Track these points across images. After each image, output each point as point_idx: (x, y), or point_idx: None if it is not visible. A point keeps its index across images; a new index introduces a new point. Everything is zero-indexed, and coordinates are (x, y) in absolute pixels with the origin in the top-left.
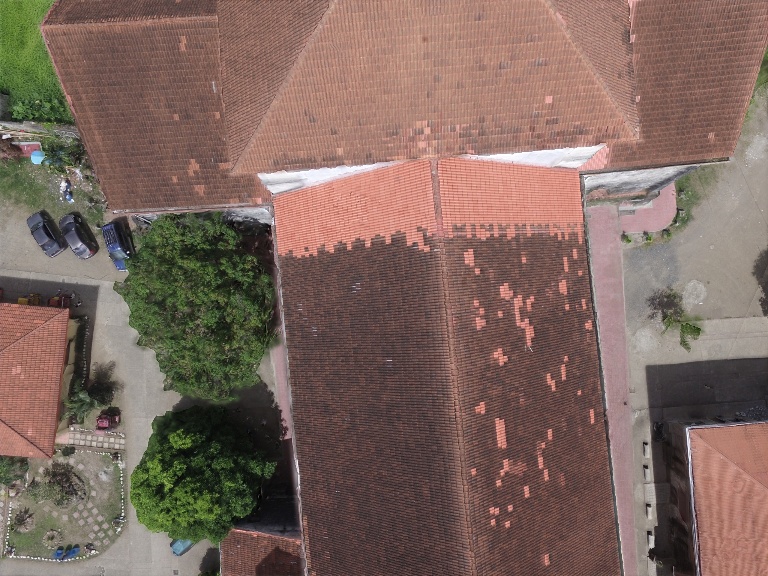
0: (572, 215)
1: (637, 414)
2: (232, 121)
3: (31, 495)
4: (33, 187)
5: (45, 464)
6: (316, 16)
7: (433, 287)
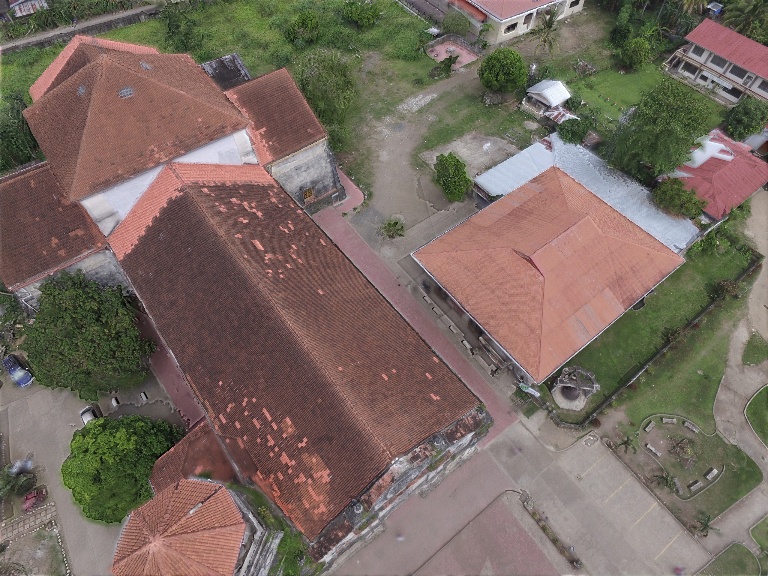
0: (266, 179)
1: (409, 286)
2: (63, 184)
3: None
4: None
5: None
6: (84, 123)
7: (190, 204)
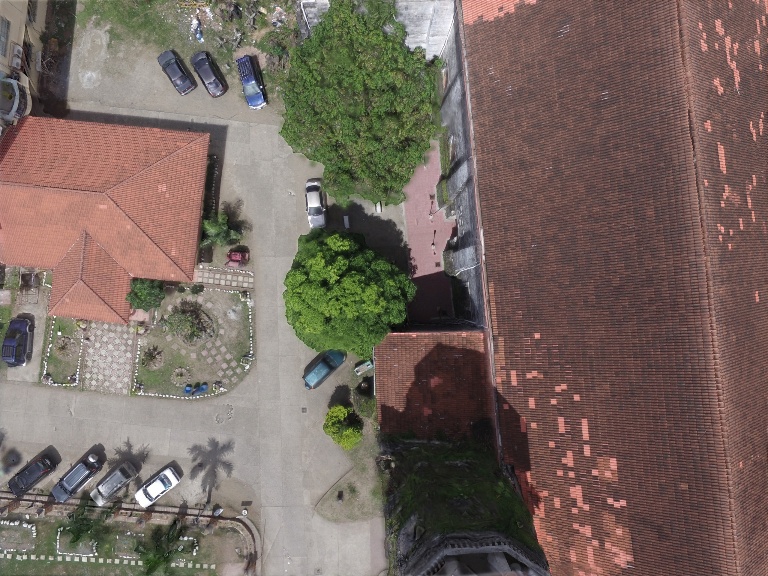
0: None
1: None
2: None
3: (166, 325)
4: (163, 27)
5: (174, 302)
6: None
7: (663, 3)
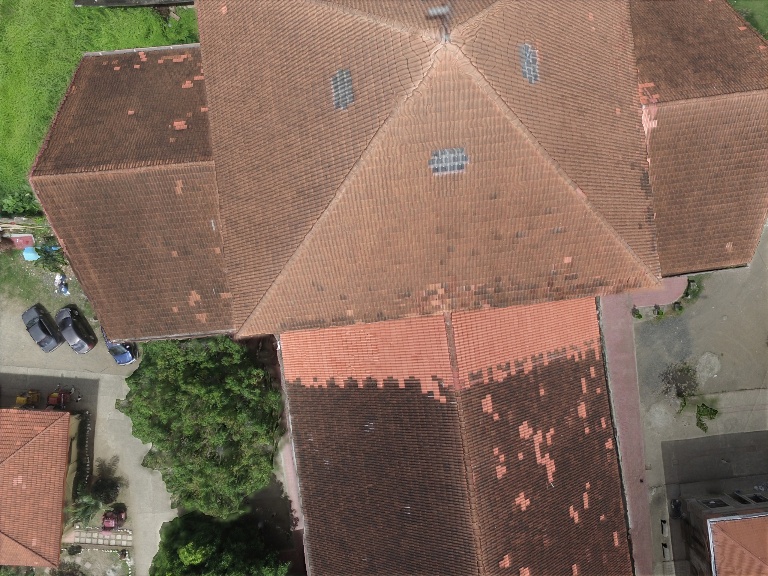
0: (588, 331)
1: (654, 491)
2: (235, 283)
3: None
4: (27, 280)
5: None
6: (322, 201)
7: (451, 440)
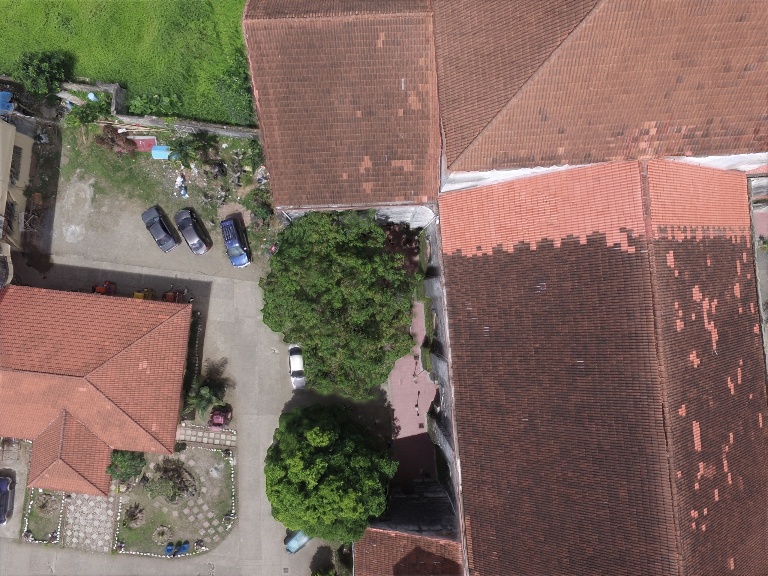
0: (742, 218)
1: None
2: (451, 119)
3: (147, 491)
4: (147, 182)
5: (156, 460)
6: (578, 14)
7: (638, 288)
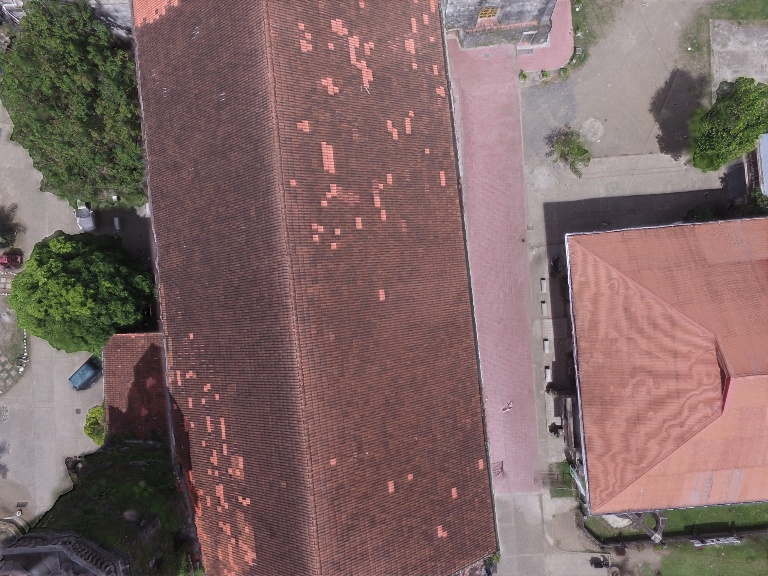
0: None
1: (535, 251)
2: None
3: None
4: None
5: None
6: None
7: (254, 4)
